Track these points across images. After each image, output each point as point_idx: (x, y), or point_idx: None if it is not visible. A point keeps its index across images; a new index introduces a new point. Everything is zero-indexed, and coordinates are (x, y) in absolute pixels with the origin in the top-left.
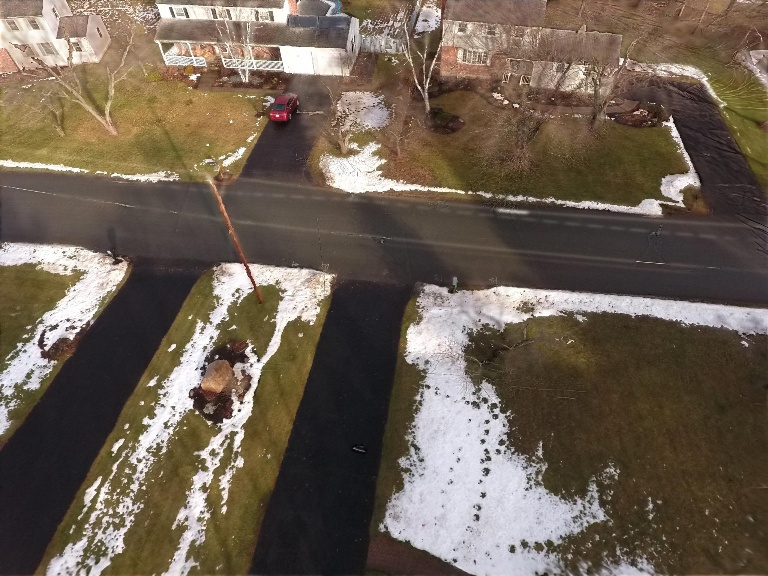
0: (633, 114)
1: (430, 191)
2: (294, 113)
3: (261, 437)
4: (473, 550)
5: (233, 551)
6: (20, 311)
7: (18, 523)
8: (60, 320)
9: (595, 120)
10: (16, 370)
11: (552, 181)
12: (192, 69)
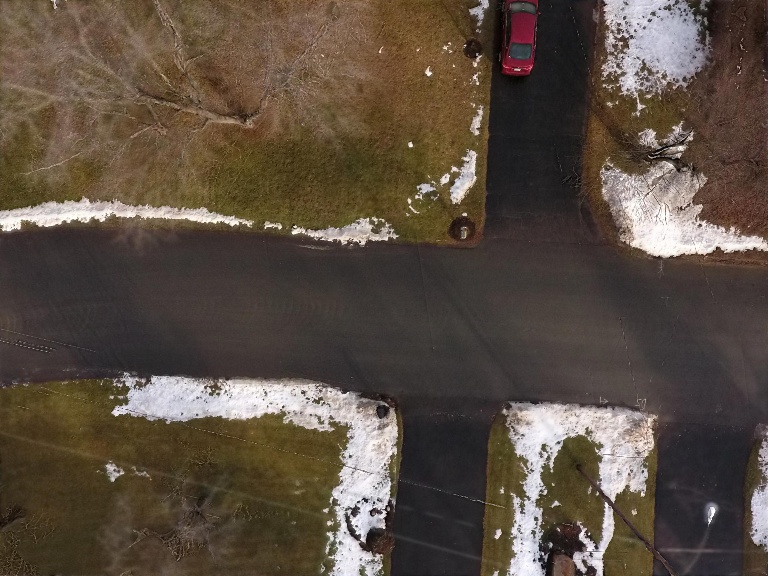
0: None
1: None
2: None
3: None
4: None
5: None
6: (303, 488)
7: None
8: (357, 501)
9: None
10: (346, 567)
11: None
12: None
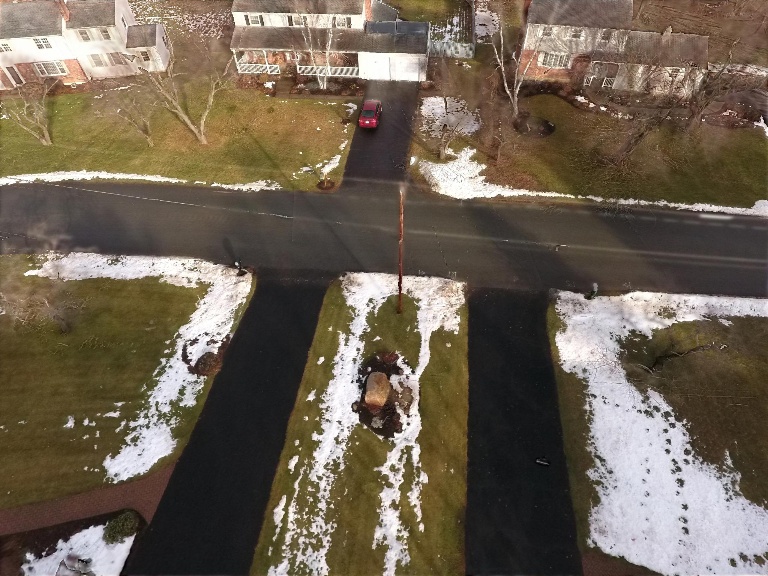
0: (722, 115)
1: (539, 196)
2: (380, 119)
3: (439, 451)
4: (694, 565)
5: (443, 571)
6: (154, 325)
7: (213, 546)
8: (198, 334)
9: (691, 122)
10: (167, 386)
11: (659, 184)
12: (266, 77)
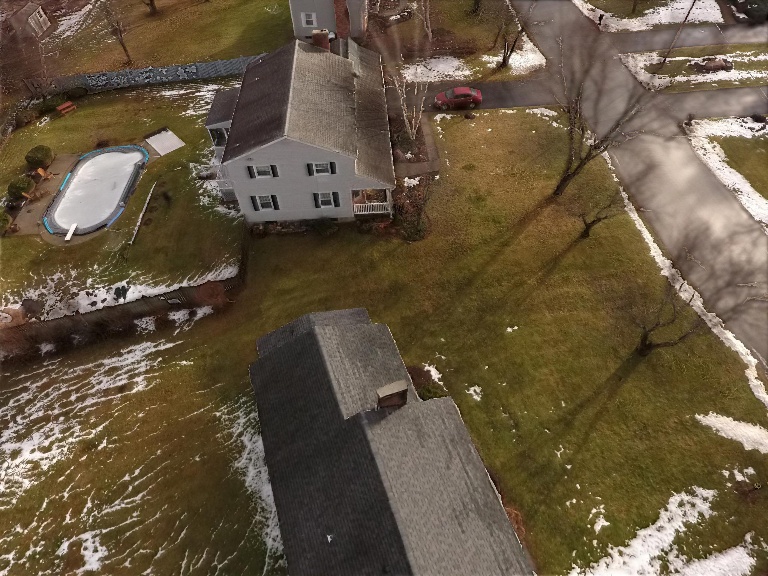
0: None
1: None
2: None
3: (724, 50)
4: None
5: (765, 46)
6: (759, 149)
7: None
8: (745, 129)
9: None
10: None
11: (489, 3)
12: None
